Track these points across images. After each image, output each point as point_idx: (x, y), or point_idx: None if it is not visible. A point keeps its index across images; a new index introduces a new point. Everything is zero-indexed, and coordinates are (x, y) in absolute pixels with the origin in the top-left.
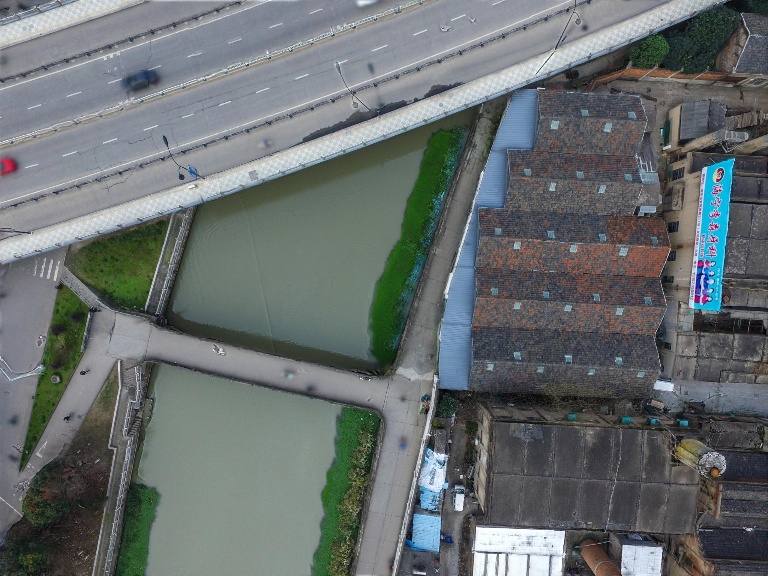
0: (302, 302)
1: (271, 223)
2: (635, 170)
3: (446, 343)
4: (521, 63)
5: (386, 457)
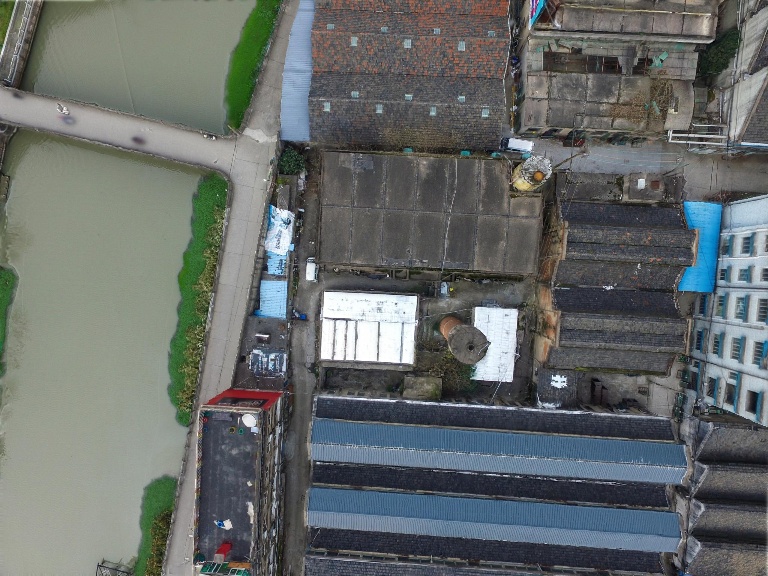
0: (163, 84)
1: (131, 2)
2: None
3: (287, 91)
4: None
5: (235, 224)
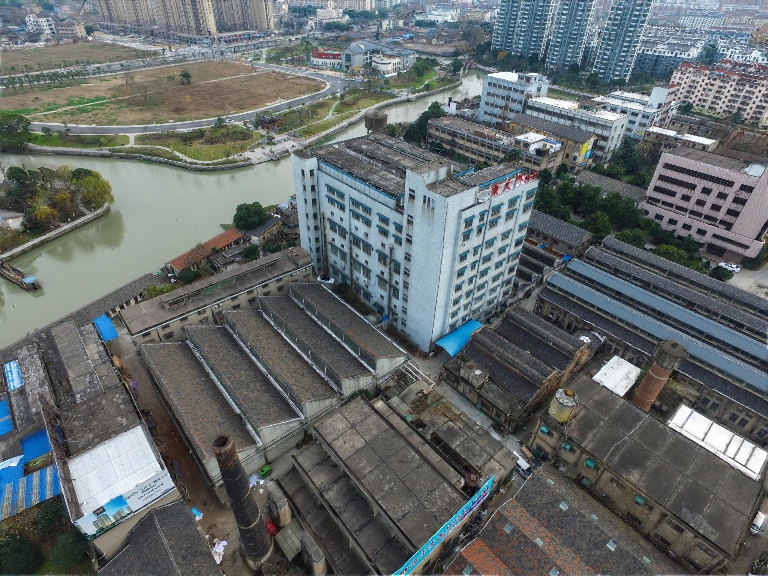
0: None
1: None
2: None
3: None
4: None
5: None
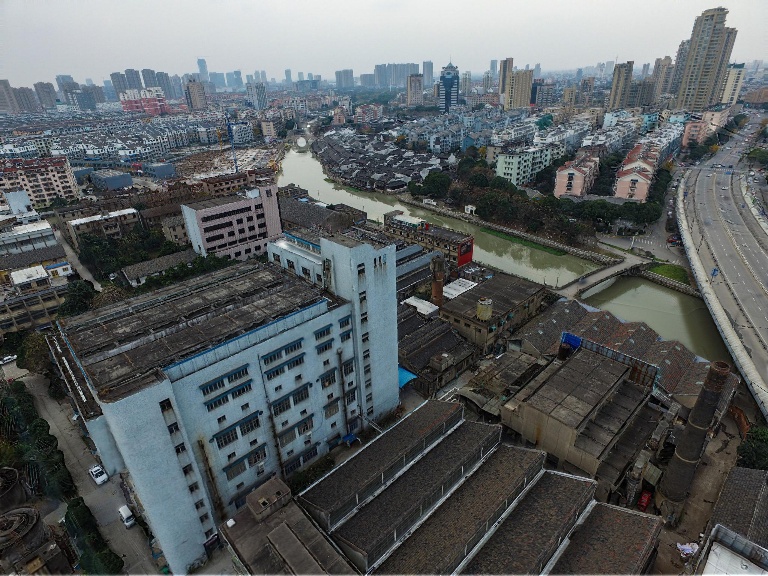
0: None
1: None
2: (662, 383)
3: None
4: (763, 380)
5: None
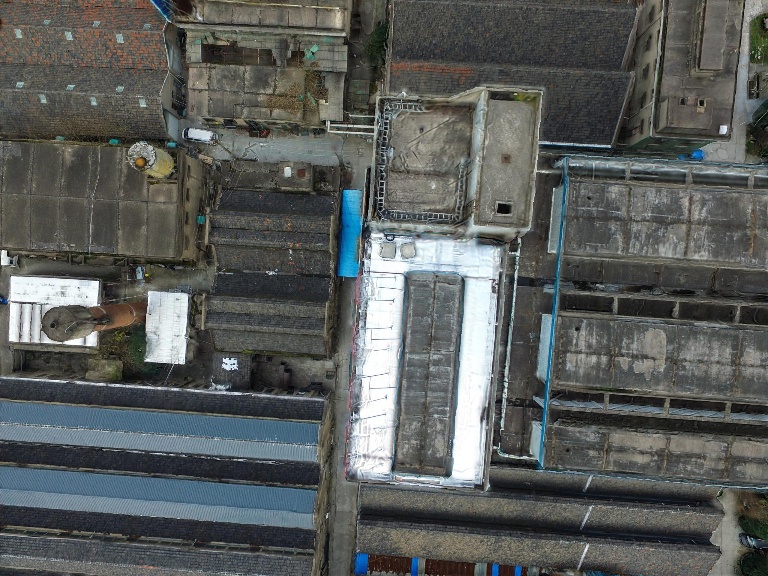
0: None
1: None
2: None
3: None
4: None
5: None
